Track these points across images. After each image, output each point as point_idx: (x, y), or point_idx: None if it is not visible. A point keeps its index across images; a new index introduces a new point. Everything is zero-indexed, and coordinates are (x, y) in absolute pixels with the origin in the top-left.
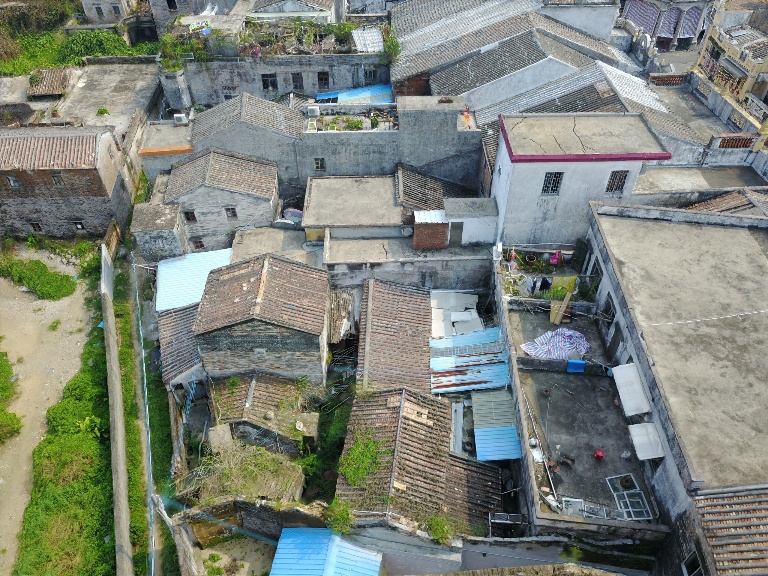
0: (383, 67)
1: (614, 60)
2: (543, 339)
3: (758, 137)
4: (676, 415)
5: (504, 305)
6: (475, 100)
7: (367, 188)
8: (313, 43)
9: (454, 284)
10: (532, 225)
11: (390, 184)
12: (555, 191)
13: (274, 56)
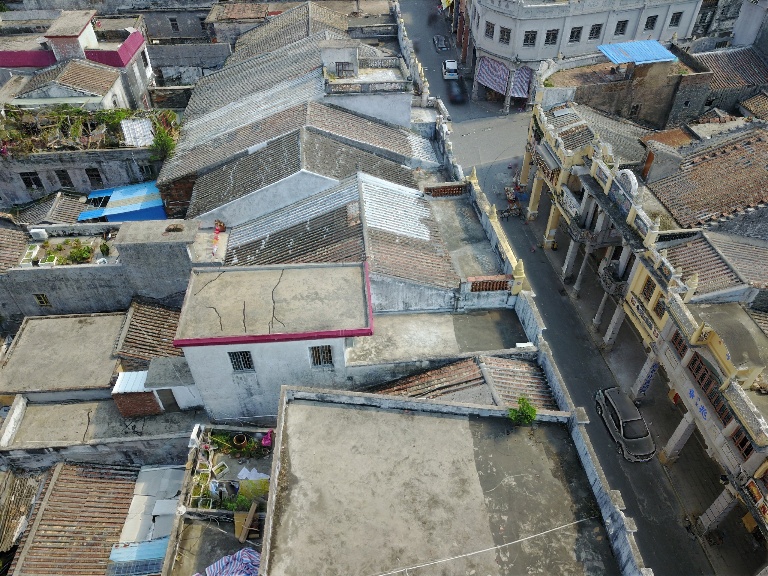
0: (159, 161)
1: (405, 157)
2: (216, 568)
3: (513, 280)
4: None
5: (174, 522)
6: (229, 216)
7: (88, 332)
8: (84, 133)
9: (169, 459)
10: (238, 400)
11: (118, 325)
12: (250, 368)
13: (28, 154)
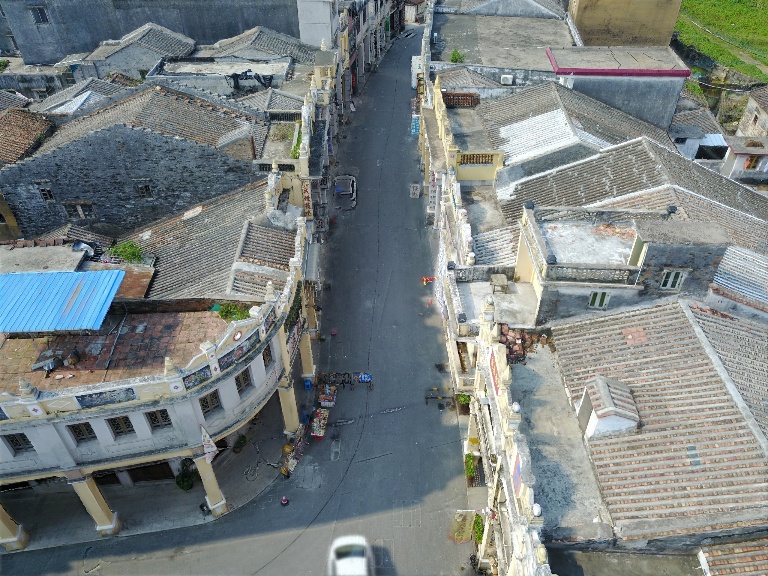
0: None
1: None
2: None
3: None
4: (565, 30)
5: None
6: None
7: None
8: None
9: None
10: None
11: None
12: None
13: None
